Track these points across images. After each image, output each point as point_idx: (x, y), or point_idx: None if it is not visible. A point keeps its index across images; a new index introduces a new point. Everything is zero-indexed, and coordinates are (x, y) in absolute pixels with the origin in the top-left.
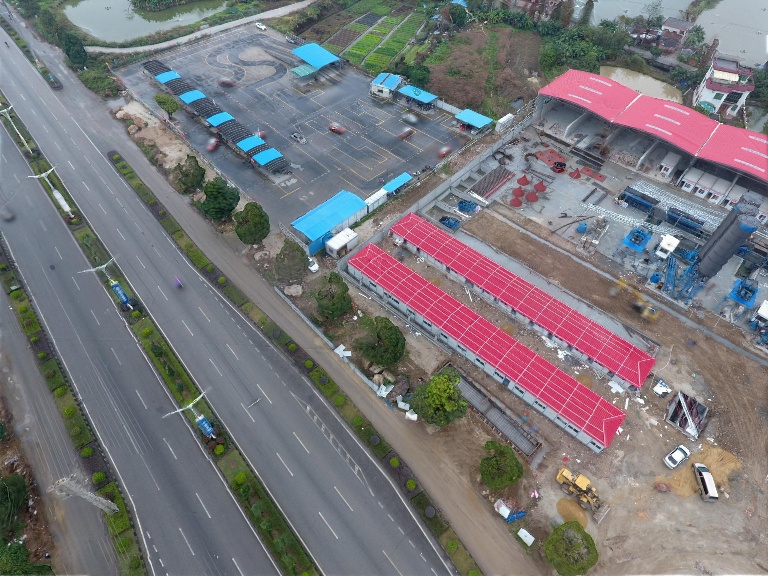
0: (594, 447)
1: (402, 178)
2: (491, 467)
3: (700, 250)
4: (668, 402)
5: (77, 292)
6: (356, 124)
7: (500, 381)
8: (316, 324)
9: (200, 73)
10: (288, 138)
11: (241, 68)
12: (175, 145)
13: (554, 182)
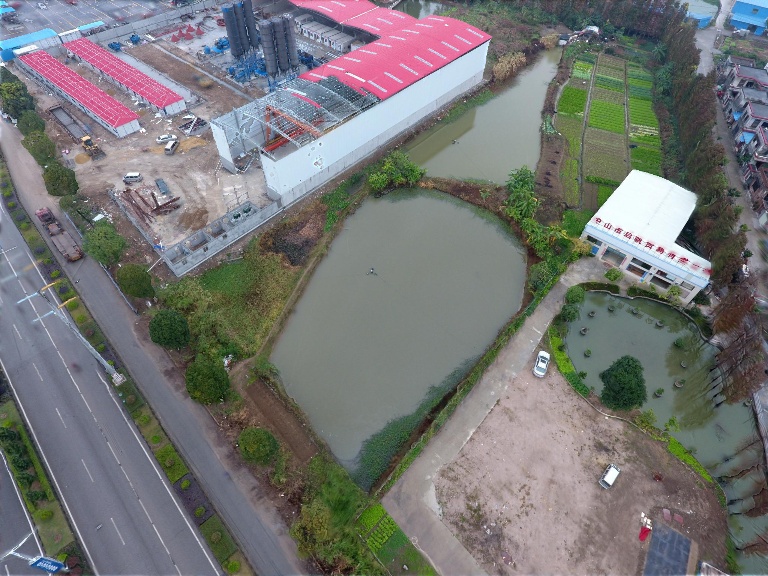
0: (116, 133)
1: (96, 23)
2: None
3: None
4: None
5: None
6: (93, 0)
7: (84, 111)
8: None
9: None
10: (34, 7)
11: None
12: None
13: (213, 30)
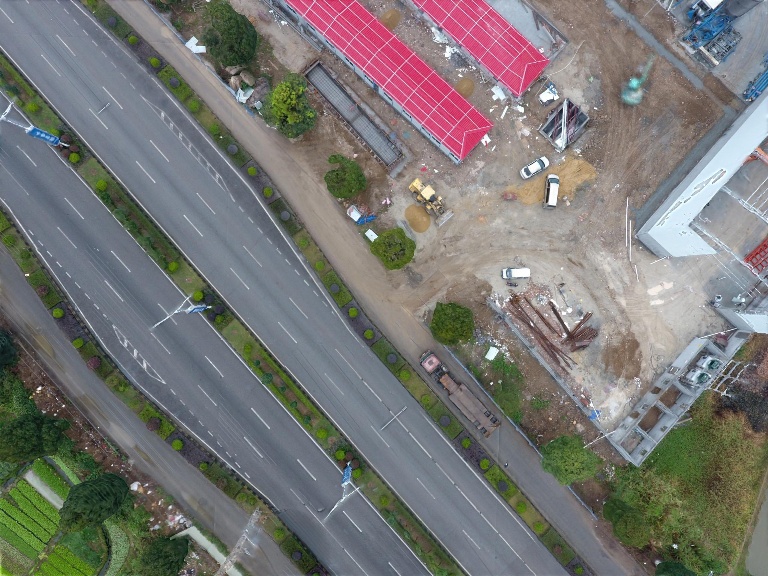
0: (453, 158)
1: None
2: (331, 180)
3: None
4: (550, 111)
5: None
6: None
7: (371, 85)
8: (160, 8)
9: None
10: None
11: None
12: None
13: None
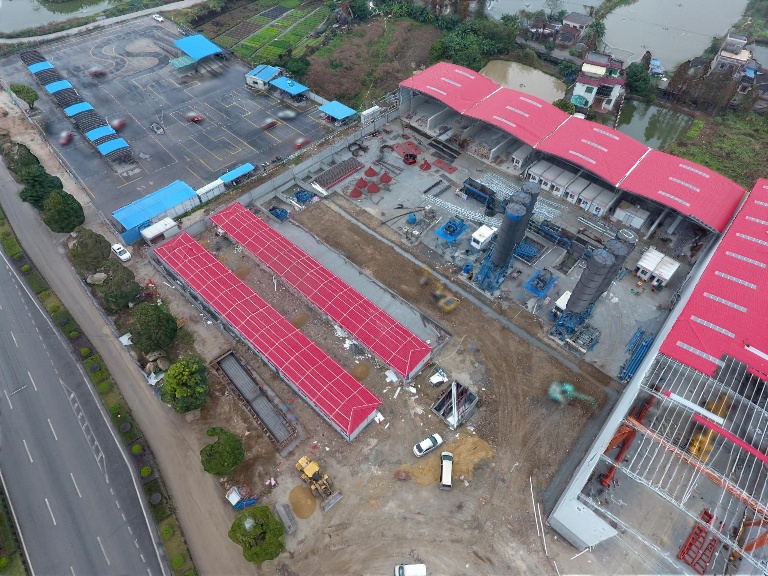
0: (344, 435)
1: (243, 168)
2: (205, 453)
3: (528, 242)
4: (441, 391)
5: None
6: (221, 115)
7: (274, 369)
8: (110, 312)
9: (80, 64)
10: (146, 128)
11: (124, 59)
12: (29, 135)
13: (402, 174)
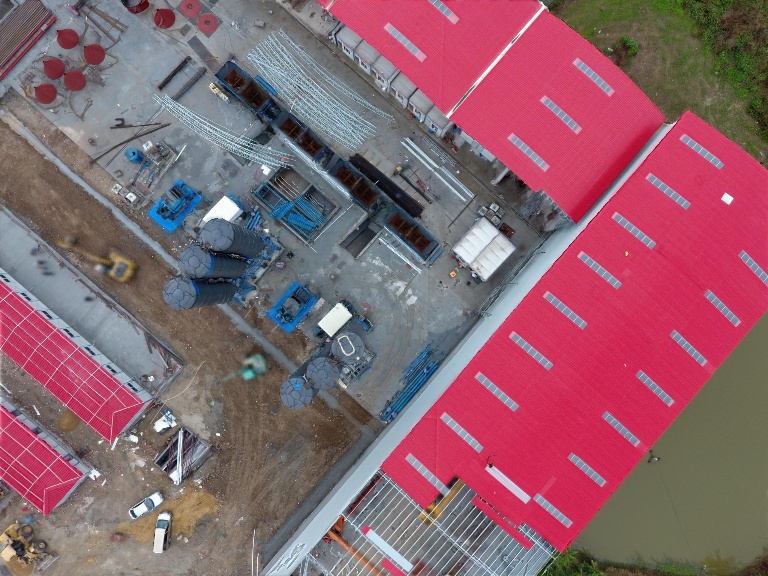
0: None
1: None
2: None
3: None
4: (168, 438)
5: None
6: None
7: None
8: None
9: None
10: None
11: None
12: None
13: (122, 39)
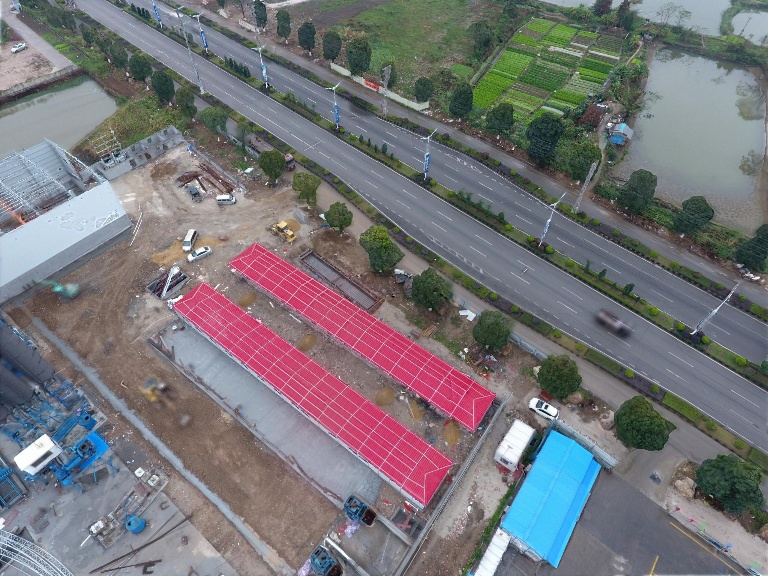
0: None
1: None
2: None
3: None
4: (177, 293)
5: (767, 353)
6: None
7: None
8: None
9: None
10: None
11: None
12: None
13: None
